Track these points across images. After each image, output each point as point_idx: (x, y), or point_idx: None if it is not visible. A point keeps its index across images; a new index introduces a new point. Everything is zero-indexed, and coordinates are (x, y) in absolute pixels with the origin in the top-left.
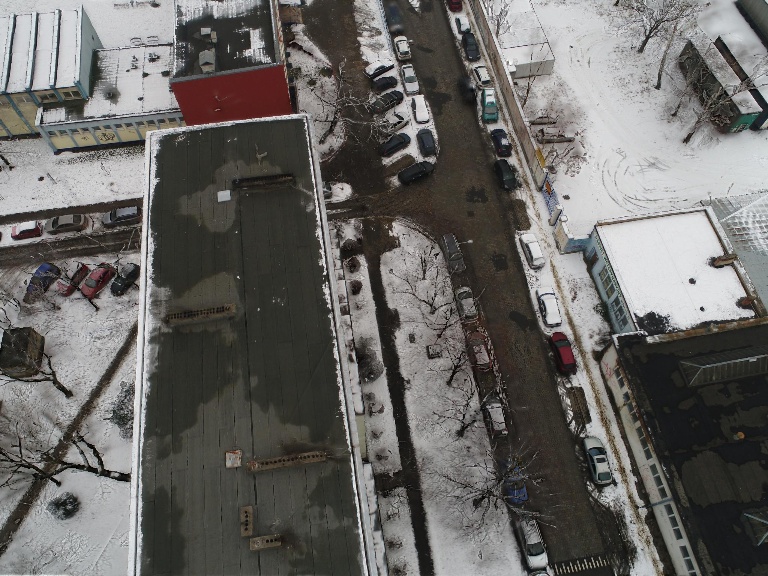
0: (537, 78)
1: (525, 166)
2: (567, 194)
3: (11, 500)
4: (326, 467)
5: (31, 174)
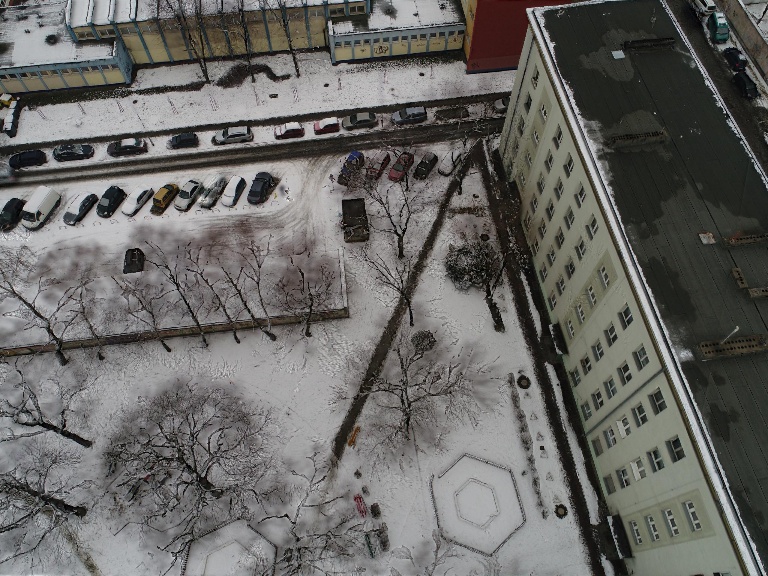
0: (755, 6)
1: (760, 79)
2: None
3: (374, 336)
4: None
5: (317, 81)
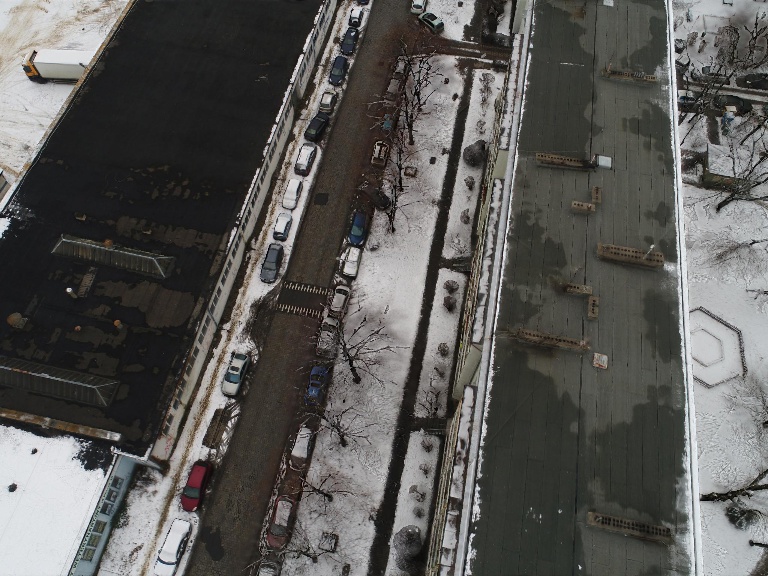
0: None
1: None
2: None
3: None
4: None
5: None
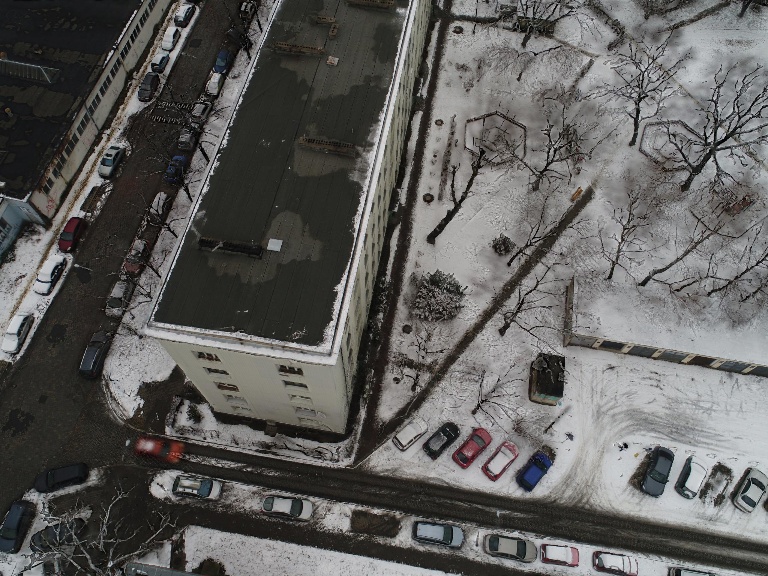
0: None
1: None
2: None
3: None
4: None
5: None
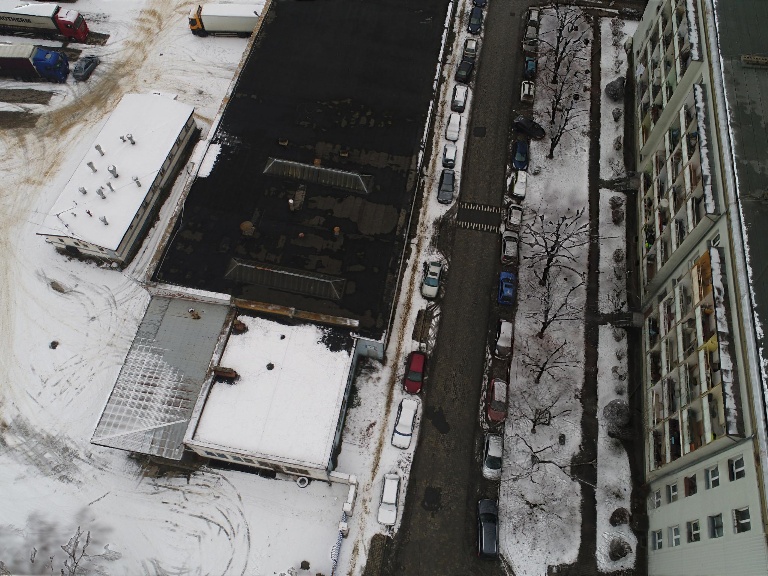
0: None
1: None
2: (301, 571)
3: None
4: (760, 194)
5: None
